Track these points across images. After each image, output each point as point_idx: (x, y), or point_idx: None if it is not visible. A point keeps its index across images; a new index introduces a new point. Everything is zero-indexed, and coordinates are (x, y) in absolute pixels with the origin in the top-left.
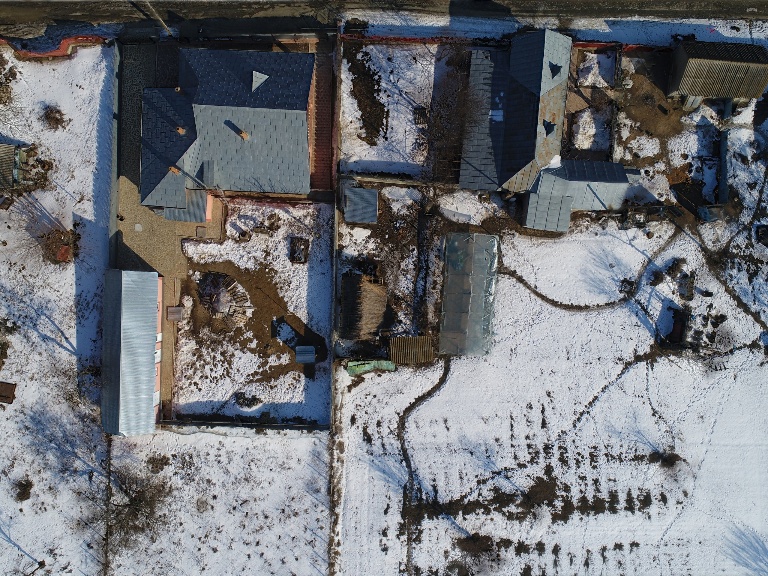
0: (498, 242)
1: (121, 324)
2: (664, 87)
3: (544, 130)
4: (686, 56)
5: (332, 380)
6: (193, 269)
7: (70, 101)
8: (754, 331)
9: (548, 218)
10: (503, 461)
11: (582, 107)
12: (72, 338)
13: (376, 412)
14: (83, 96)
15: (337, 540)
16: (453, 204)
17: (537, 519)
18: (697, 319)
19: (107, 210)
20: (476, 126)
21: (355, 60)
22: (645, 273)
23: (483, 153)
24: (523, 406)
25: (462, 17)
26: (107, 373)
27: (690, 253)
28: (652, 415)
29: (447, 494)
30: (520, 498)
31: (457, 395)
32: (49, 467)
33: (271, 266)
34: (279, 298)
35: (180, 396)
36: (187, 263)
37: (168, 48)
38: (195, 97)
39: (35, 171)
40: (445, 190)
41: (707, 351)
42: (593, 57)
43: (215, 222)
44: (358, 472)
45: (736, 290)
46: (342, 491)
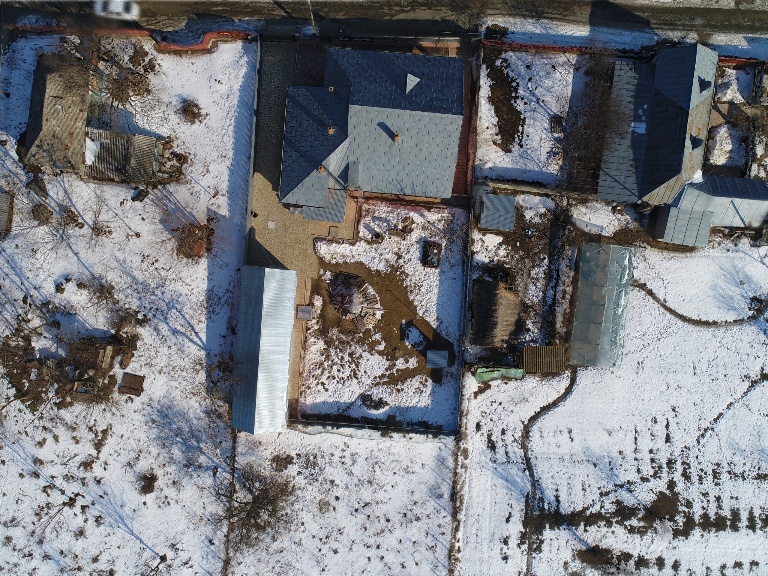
0: (630, 254)
1: (261, 321)
2: None
3: (690, 144)
4: None
5: (460, 386)
6: (324, 269)
7: (208, 95)
8: None
9: (687, 233)
10: (626, 474)
11: (718, 122)
12: (202, 333)
13: (501, 420)
14: (221, 91)
15: (458, 546)
16: (586, 214)
17: (658, 534)
18: None
19: (242, 206)
20: (617, 137)
21: (494, 66)
22: None
23: (623, 165)
24: (648, 420)
25: (602, 27)
26: (242, 370)
27: None
28: None
29: (569, 505)
30: (642, 512)
31: (582, 406)
32: (174, 461)
33: (402, 269)
34: (409, 301)
35: (307, 395)
36: (318, 262)
37: (308, 46)
38: (350, 97)
39: (170, 164)
40: (578, 200)
41: None
42: (732, 73)
43: (348, 222)
44: (481, 479)
45: None
46: (464, 497)
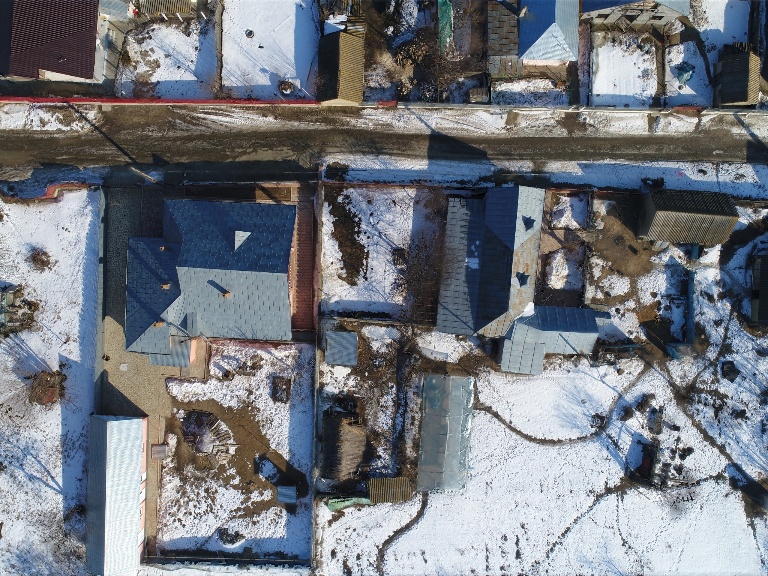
0: None
1: (106, 473)
2: (634, 228)
3: (518, 282)
4: (654, 207)
5: (313, 516)
6: (177, 407)
7: (56, 243)
8: (720, 463)
9: (522, 362)
10: None
11: (555, 248)
12: (58, 477)
13: (356, 545)
14: (69, 238)
15: None
16: (431, 343)
17: None
18: (665, 452)
19: (93, 351)
20: (453, 272)
21: (336, 203)
22: (616, 408)
23: (459, 299)
24: (498, 538)
25: (440, 160)
26: (92, 518)
27: (659, 389)
28: (622, 545)
29: None
30: None
31: (434, 528)
32: None
33: (254, 404)
34: (261, 435)
35: (164, 533)
36: (171, 402)
37: (153, 191)
38: (179, 258)
39: (22, 312)
40: (423, 329)
41: (675, 483)
42: (566, 200)
43: (199, 362)
44: None
45: (702, 424)
46: None
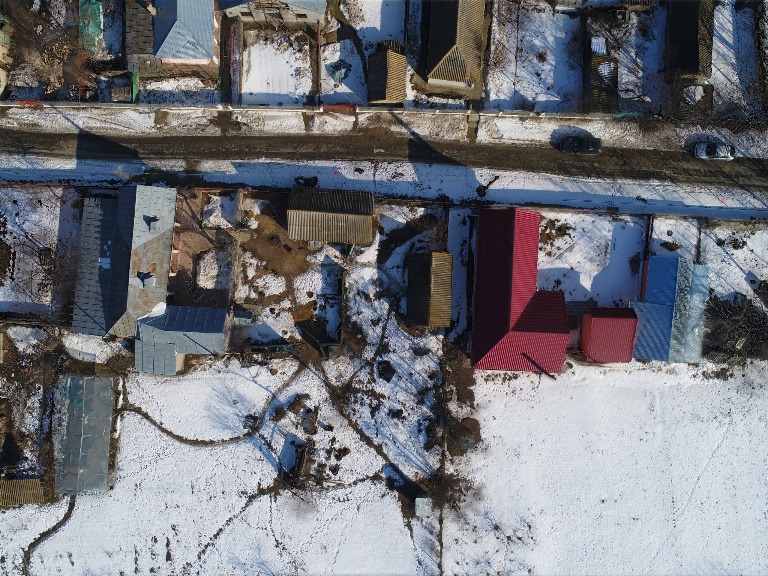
0: (122, 380)
1: None
2: None
3: (140, 282)
4: (288, 206)
5: None
6: None
7: None
8: (376, 463)
9: (155, 363)
10: None
11: (207, 248)
12: None
13: (0, 548)
14: None
15: None
16: (78, 343)
17: None
18: (320, 452)
19: None
20: (87, 272)
21: None
22: (269, 409)
23: (93, 299)
24: (148, 540)
25: (89, 160)
26: None
27: (313, 389)
28: (275, 546)
29: None
30: None
31: (81, 530)
32: None
33: None
34: None
35: None
36: None
37: None
38: None
39: None
40: (71, 329)
41: (330, 483)
42: (217, 199)
43: None
44: None
45: (359, 424)
46: None
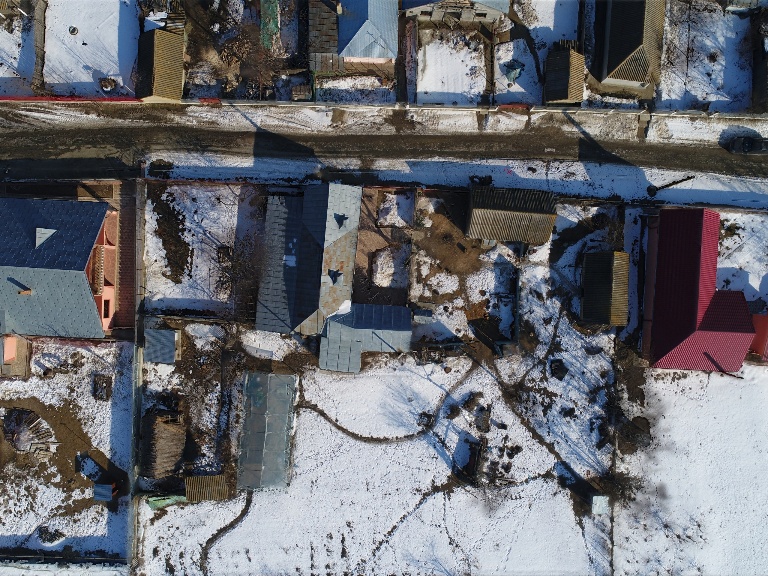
0: (299, 378)
1: None
2: (463, 226)
3: (330, 279)
4: (472, 205)
5: (133, 514)
6: None
7: None
8: (548, 461)
9: (339, 360)
10: None
11: (382, 246)
12: None
13: (179, 544)
14: None
15: None
16: (255, 341)
17: None
18: (493, 450)
19: None
20: (271, 270)
21: (160, 200)
22: (443, 406)
23: (277, 297)
24: (323, 536)
25: (266, 158)
26: None
27: (486, 387)
28: (449, 544)
29: None
30: None
31: (259, 526)
32: None
33: (75, 402)
34: (83, 433)
35: None
36: None
37: None
38: None
39: None
40: (248, 327)
41: (503, 481)
42: (393, 198)
43: (20, 359)
44: None
45: (531, 422)
46: None
